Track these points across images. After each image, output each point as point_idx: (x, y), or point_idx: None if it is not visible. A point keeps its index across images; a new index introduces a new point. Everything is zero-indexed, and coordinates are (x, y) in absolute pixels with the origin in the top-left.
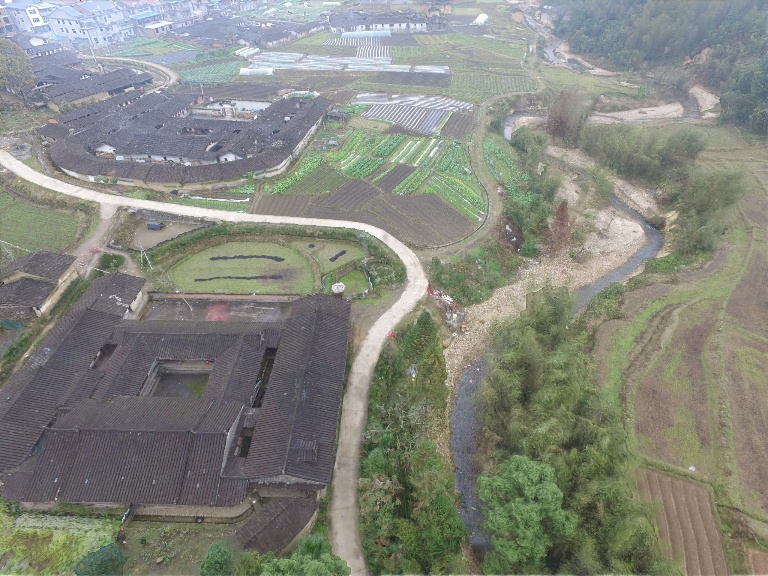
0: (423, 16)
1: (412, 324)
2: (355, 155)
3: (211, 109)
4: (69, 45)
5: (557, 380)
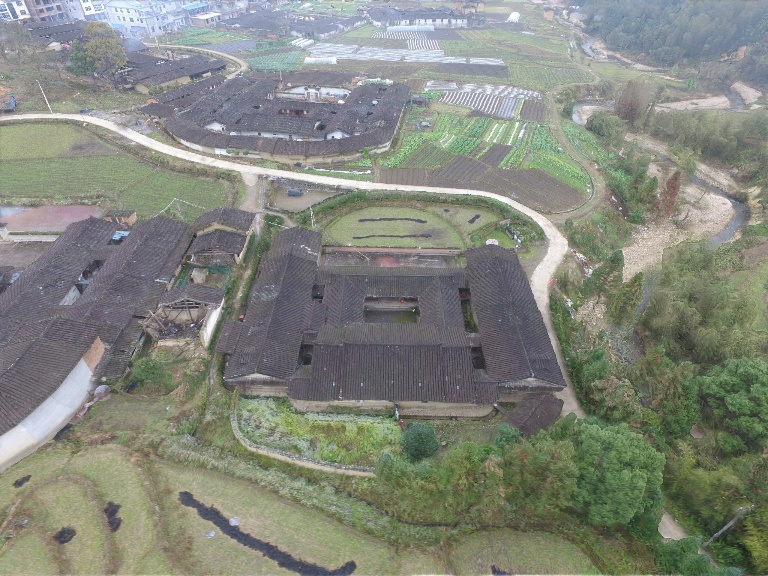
0: (458, 13)
1: (567, 273)
2: (451, 135)
3: (296, 93)
4: (126, 33)
5: (737, 307)
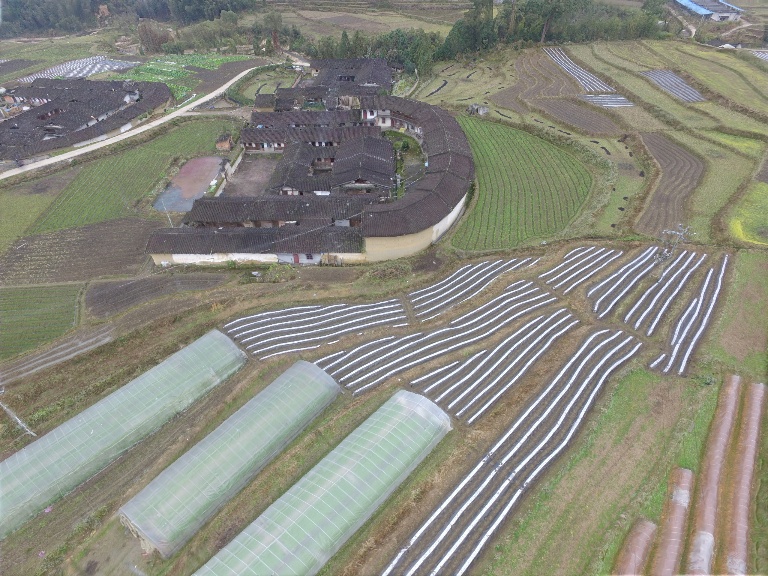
0: None
1: None
2: (156, 76)
3: None
4: None
5: (364, 35)
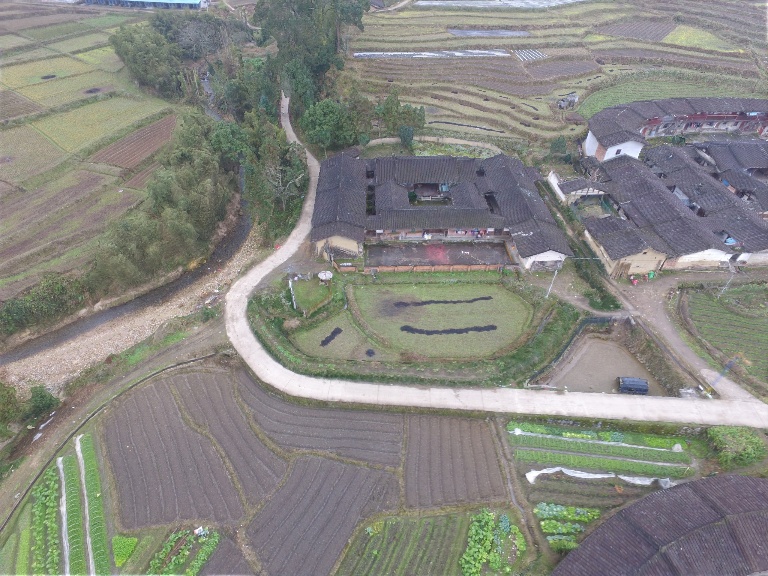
0: None
1: None
2: None
3: None
4: None
5: None
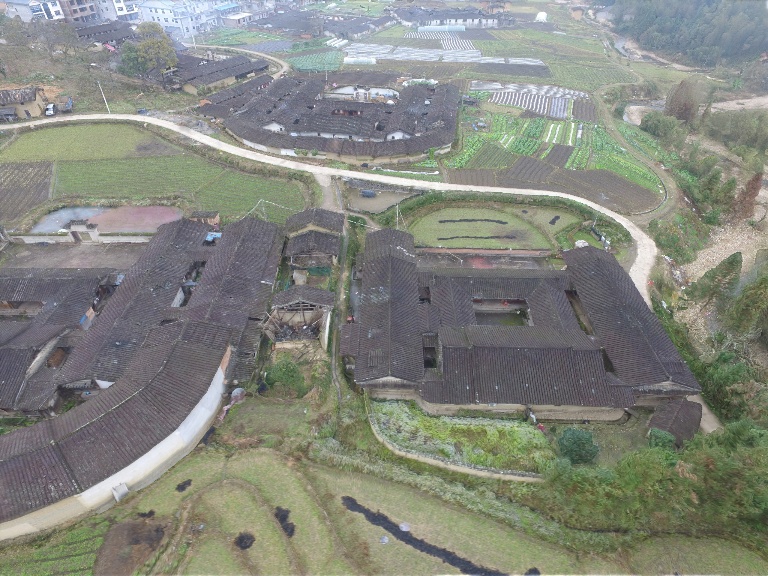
0: None
1: (663, 275)
2: (510, 135)
3: None
4: None
5: None
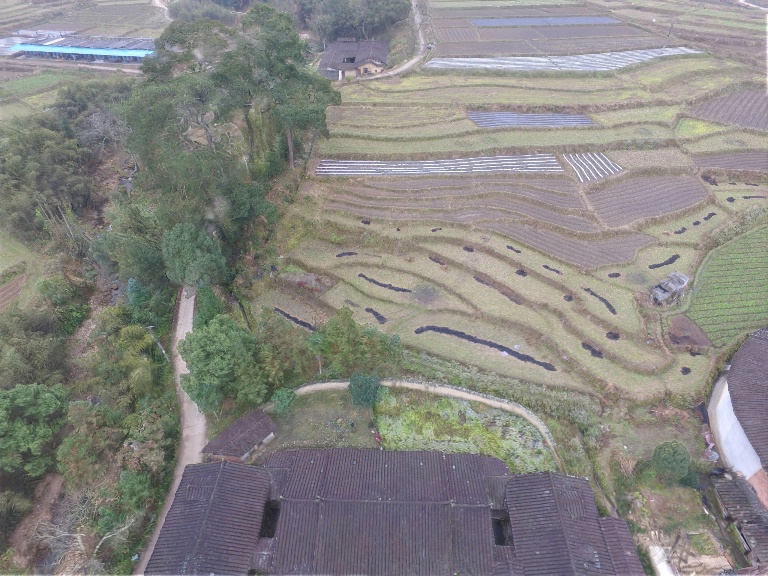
0: None
1: None
2: None
3: None
4: None
5: None
